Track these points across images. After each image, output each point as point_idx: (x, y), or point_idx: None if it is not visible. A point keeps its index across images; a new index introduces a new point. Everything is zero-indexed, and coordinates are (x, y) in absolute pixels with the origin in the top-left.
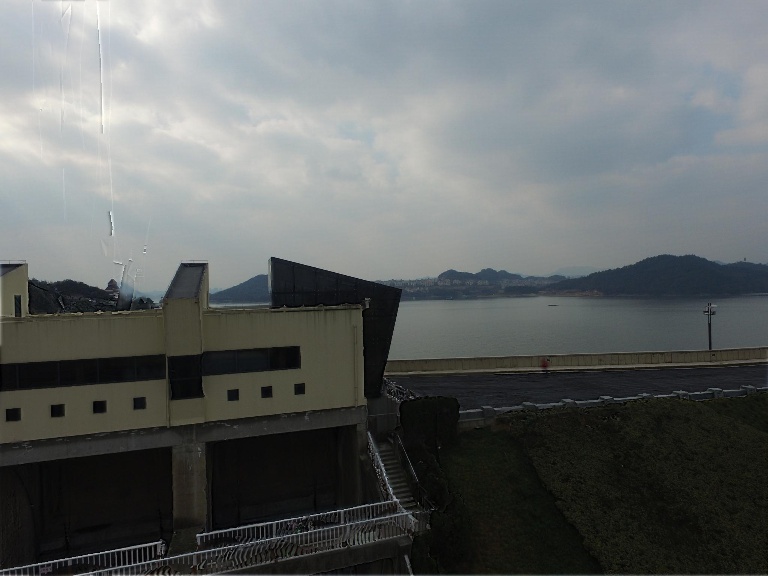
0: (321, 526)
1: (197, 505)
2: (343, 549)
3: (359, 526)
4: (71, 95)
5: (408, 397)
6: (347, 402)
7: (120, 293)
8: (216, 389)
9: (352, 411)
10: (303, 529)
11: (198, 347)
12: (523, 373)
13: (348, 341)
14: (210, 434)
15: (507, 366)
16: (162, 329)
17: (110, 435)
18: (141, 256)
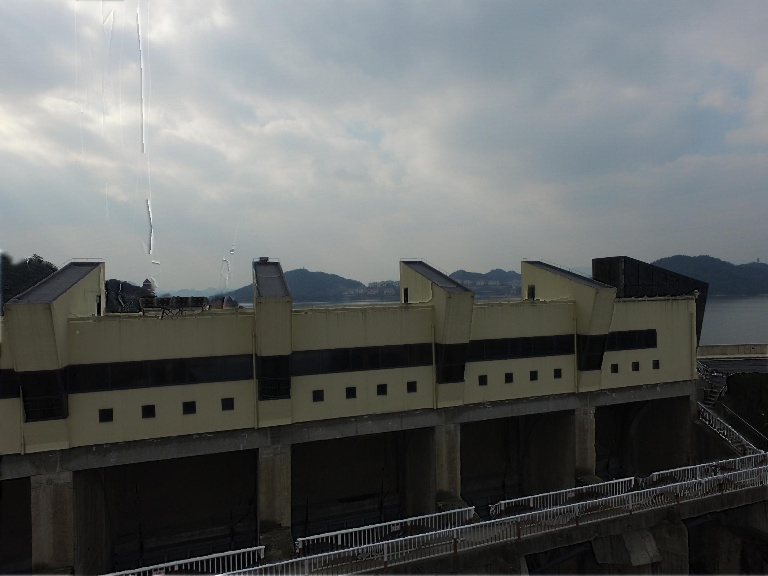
0: (724, 471)
1: (590, 457)
2: (760, 486)
3: (767, 469)
4: (111, 98)
5: (711, 374)
6: (686, 376)
7: (214, 291)
8: (604, 363)
9: (687, 384)
10: (715, 472)
11: (608, 328)
12: (738, 359)
13: (686, 326)
14: (598, 400)
15: (717, 353)
16: (571, 314)
17: (537, 399)
18: (229, 256)
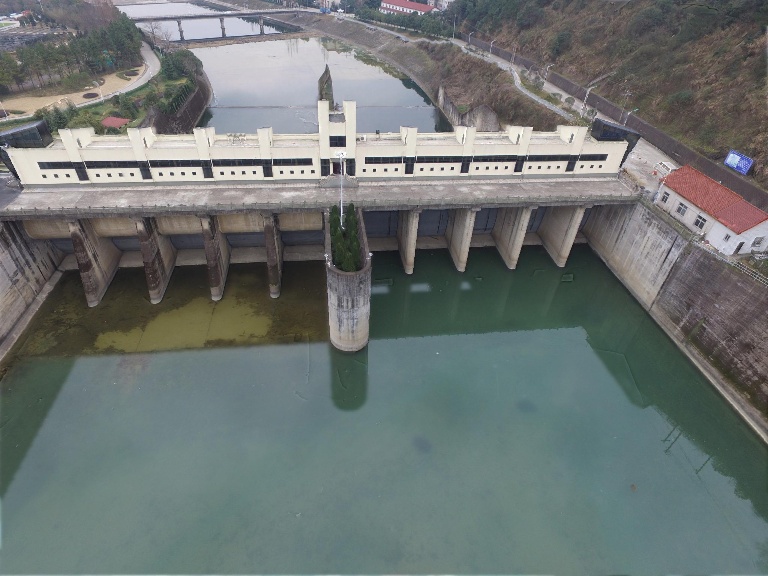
0: None
1: None
2: None
3: None
4: None
5: None
6: None
7: None
8: None
9: None
10: None
11: None
12: None
13: None
14: None
15: None
16: None
17: None
18: None
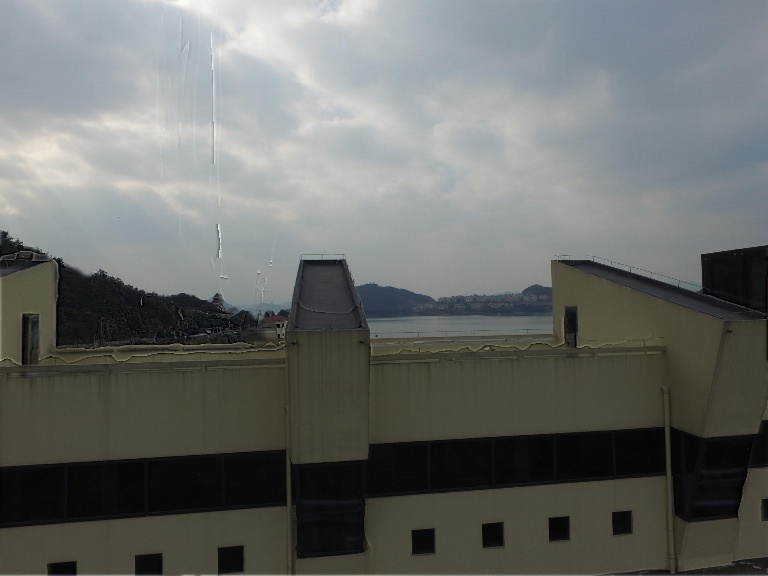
0: None
1: None
2: None
3: None
4: (187, 122)
5: None
6: None
7: (249, 306)
8: (743, 497)
9: None
10: None
11: (756, 419)
12: None
13: None
14: None
15: None
16: (655, 378)
17: None
18: (267, 269)
